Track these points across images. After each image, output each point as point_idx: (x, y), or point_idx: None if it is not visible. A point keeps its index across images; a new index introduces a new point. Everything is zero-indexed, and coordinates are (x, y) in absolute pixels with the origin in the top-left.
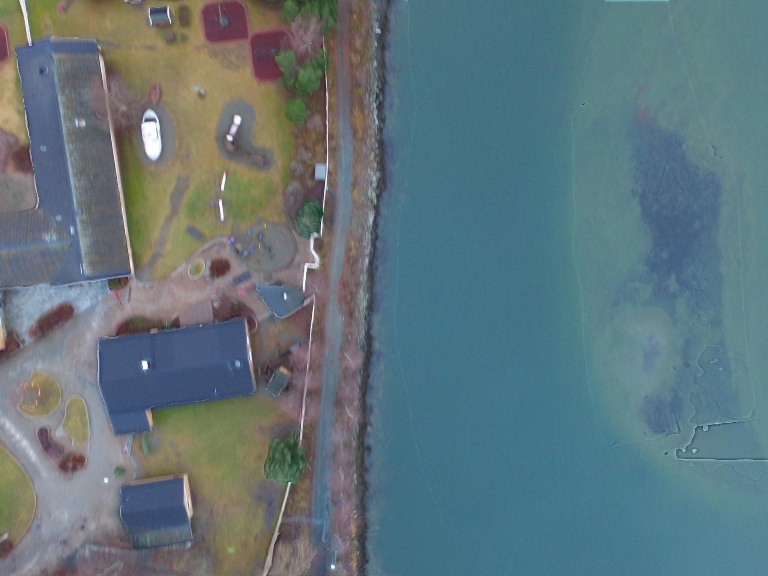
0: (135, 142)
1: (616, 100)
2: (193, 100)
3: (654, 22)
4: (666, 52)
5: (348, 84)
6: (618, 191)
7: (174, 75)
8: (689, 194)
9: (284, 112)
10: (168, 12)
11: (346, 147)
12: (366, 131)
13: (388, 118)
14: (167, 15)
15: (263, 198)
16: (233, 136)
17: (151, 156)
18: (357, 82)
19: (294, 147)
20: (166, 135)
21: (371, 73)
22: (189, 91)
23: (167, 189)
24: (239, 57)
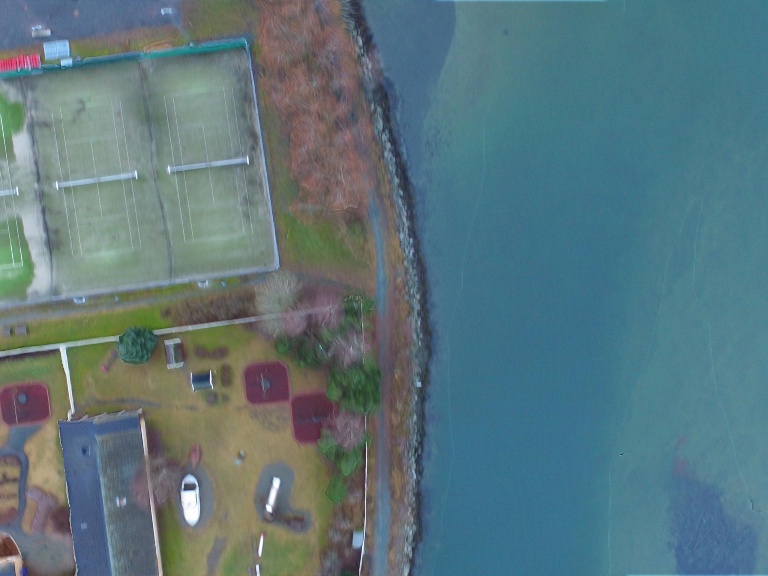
0: (174, 504)
1: (655, 451)
2: (233, 461)
3: (696, 374)
4: (707, 404)
5: (388, 444)
6: (654, 543)
7: (214, 435)
8: (725, 547)
9: (323, 474)
10: (210, 378)
11: (384, 507)
12: (404, 488)
13: (426, 468)
14: (209, 382)
15: (300, 561)
16: (272, 506)
17: (190, 521)
18: (397, 443)
19: (332, 510)
20: (205, 497)
21: (410, 428)
22: (229, 452)
23: (204, 550)
24: (280, 418)
